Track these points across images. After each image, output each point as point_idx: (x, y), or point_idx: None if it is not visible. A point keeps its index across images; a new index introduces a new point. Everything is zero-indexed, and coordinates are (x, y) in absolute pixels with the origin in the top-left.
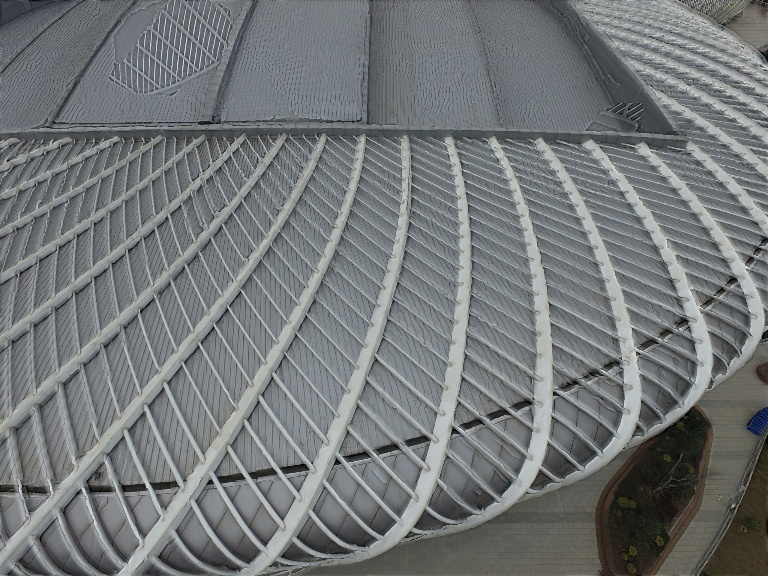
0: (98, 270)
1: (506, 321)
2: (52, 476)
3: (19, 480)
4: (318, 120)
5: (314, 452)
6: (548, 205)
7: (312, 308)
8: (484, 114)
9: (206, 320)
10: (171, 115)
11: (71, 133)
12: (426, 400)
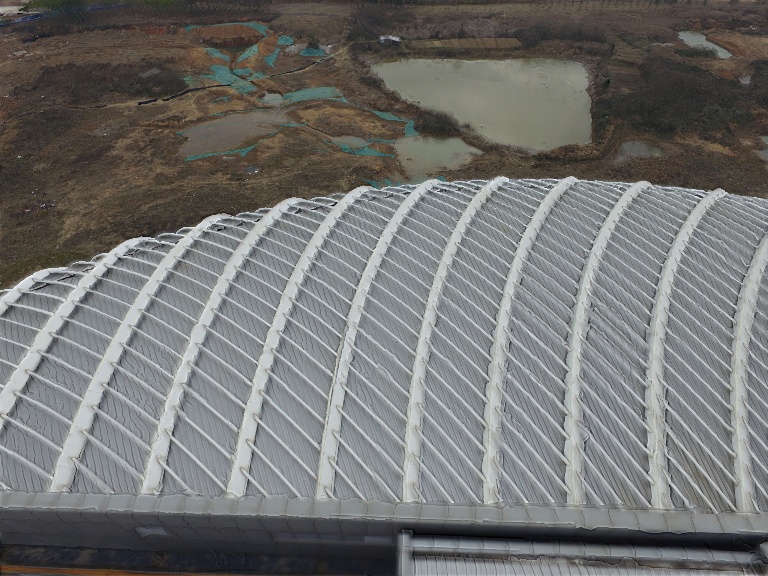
0: None
1: (282, 238)
2: None
3: None
4: None
5: None
6: (160, 343)
7: None
8: None
9: (530, 234)
10: None
11: None
12: (357, 206)
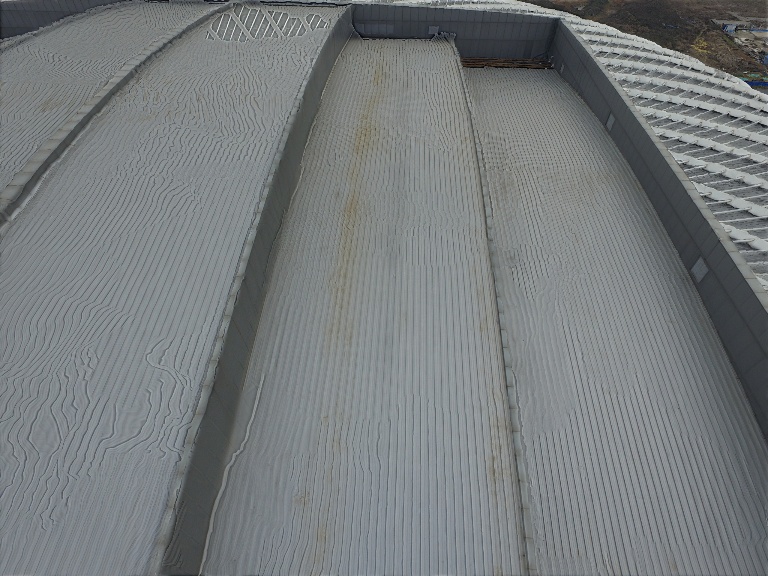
0: None
1: None
2: None
3: None
4: None
5: None
6: None
7: None
8: None
9: None
10: None
11: None
12: None
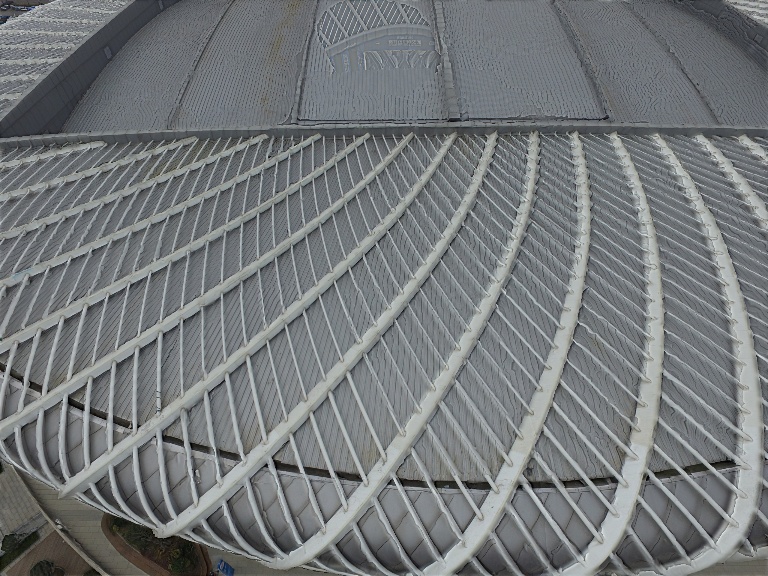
0: (431, 266)
1: None
2: (489, 472)
3: (457, 476)
4: (563, 118)
5: (738, 448)
6: None
7: (664, 304)
8: (698, 113)
9: (570, 316)
10: (408, 112)
11: (323, 130)
12: None
